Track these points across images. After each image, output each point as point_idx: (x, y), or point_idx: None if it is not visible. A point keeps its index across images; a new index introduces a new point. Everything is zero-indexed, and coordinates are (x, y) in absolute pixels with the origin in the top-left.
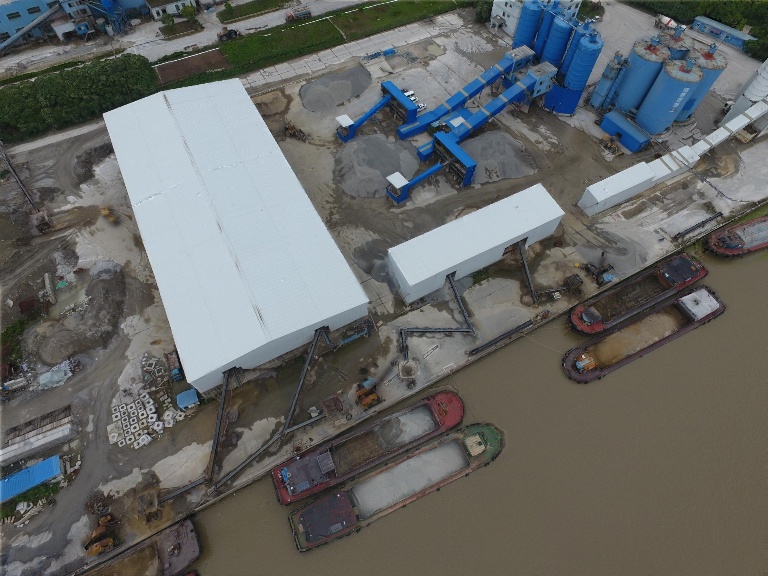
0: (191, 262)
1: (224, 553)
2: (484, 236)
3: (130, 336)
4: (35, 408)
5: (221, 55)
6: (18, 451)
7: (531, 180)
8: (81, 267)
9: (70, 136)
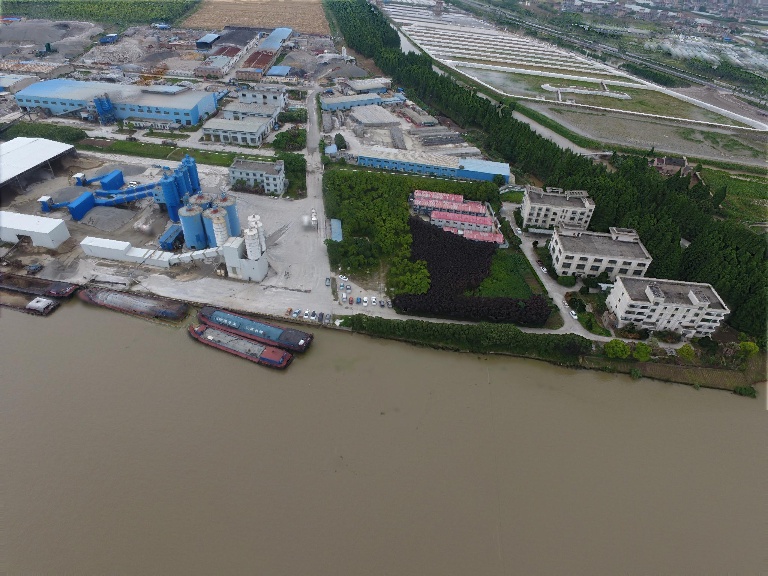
0: None
1: None
2: (9, 222)
3: None
4: None
5: None
6: None
7: (101, 232)
8: None
9: None
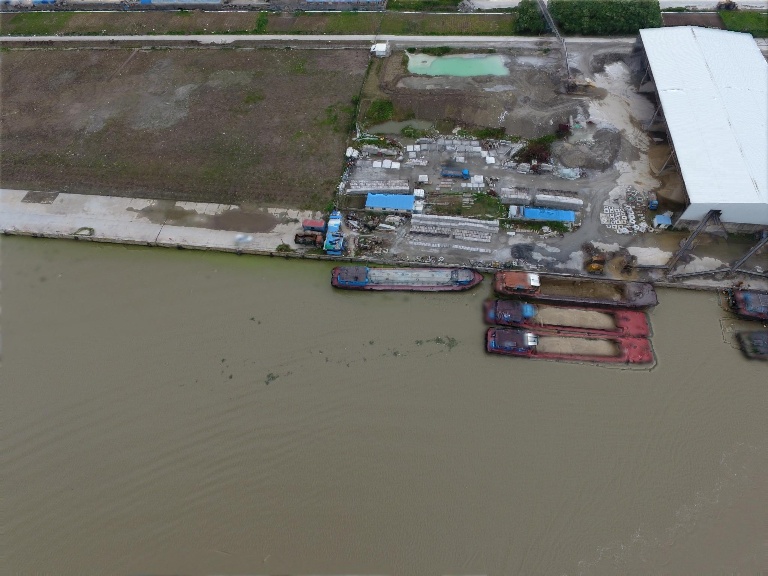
0: (702, 137)
1: (661, 317)
2: None
3: (620, 172)
4: (555, 185)
5: (719, 18)
6: (551, 199)
7: None
8: (592, 121)
9: (591, 41)
